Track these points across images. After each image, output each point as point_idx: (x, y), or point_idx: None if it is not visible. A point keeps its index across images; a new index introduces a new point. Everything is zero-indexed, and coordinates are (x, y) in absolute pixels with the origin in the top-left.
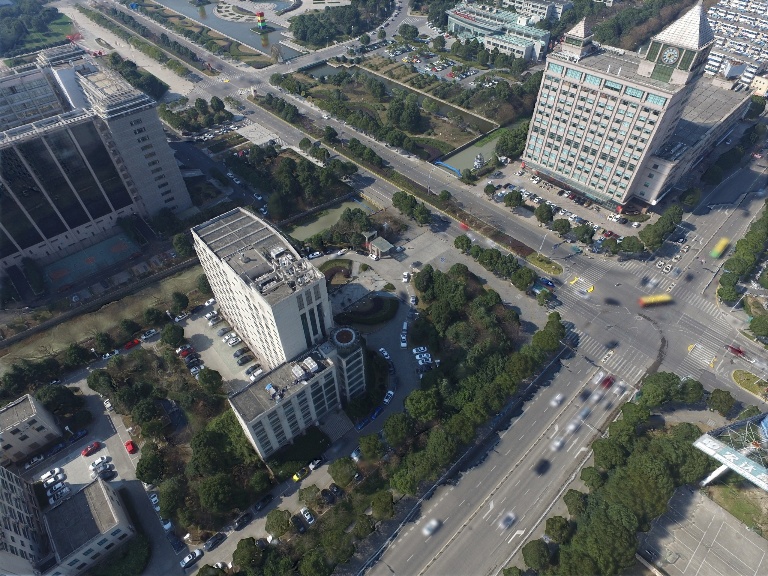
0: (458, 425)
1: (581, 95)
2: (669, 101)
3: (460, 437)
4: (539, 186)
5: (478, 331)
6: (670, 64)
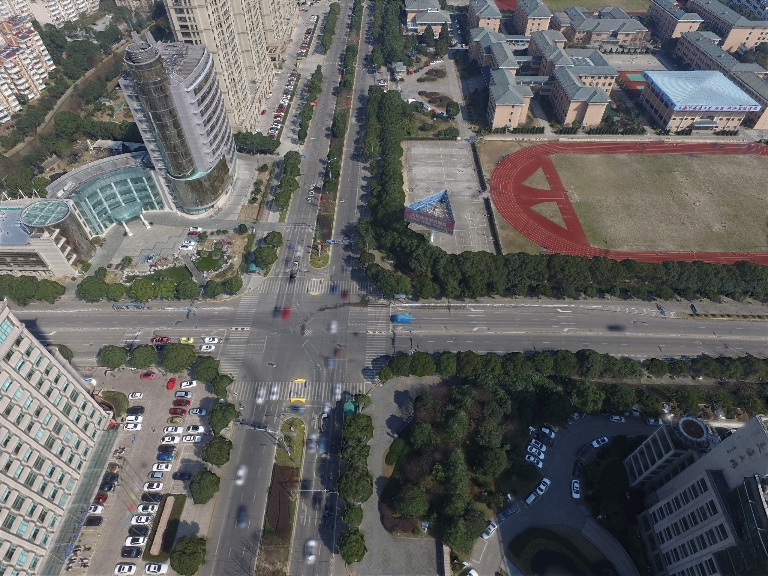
0: (571, 358)
1: None
2: None
3: (572, 355)
4: (85, 569)
5: (485, 402)
6: None
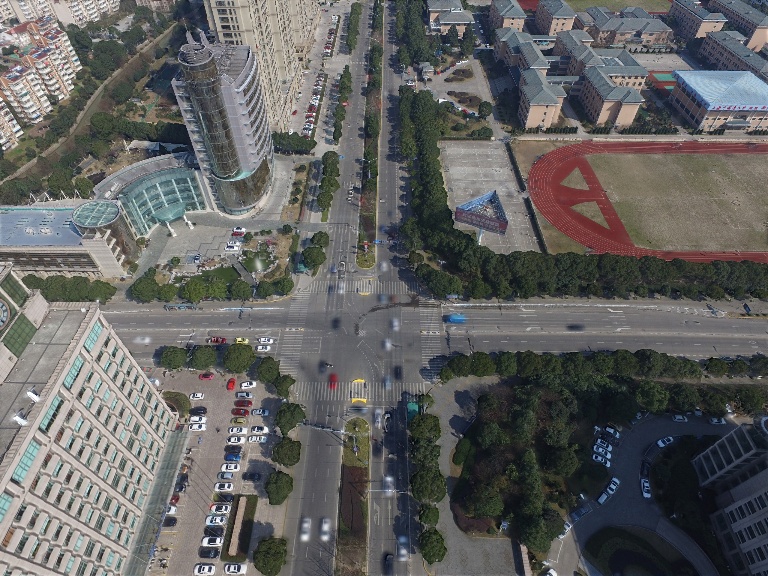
0: (632, 358)
1: (42, 493)
2: (102, 316)
3: None
4: (165, 570)
5: (552, 402)
6: (8, 319)
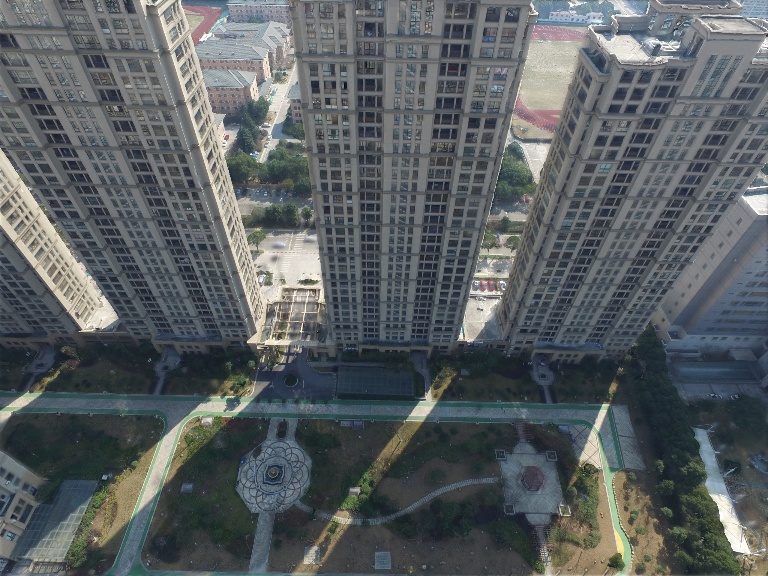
0: None
1: None
2: None
3: None
4: None
5: None
6: None
